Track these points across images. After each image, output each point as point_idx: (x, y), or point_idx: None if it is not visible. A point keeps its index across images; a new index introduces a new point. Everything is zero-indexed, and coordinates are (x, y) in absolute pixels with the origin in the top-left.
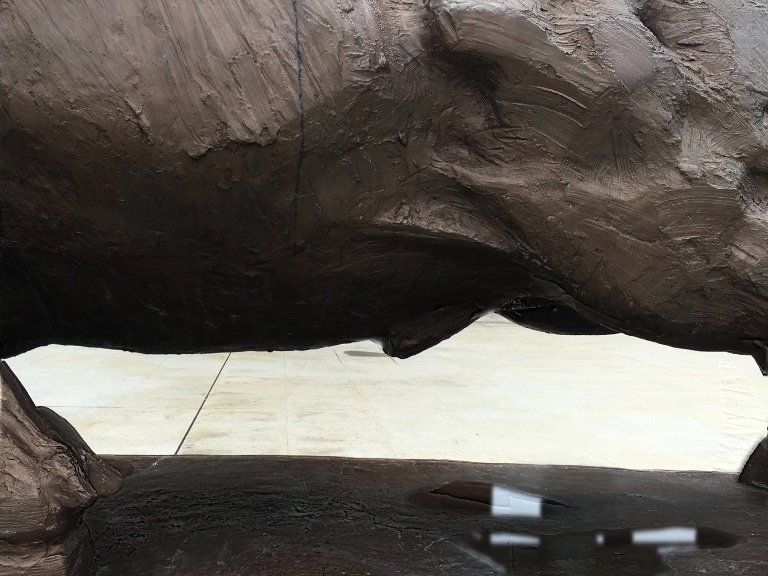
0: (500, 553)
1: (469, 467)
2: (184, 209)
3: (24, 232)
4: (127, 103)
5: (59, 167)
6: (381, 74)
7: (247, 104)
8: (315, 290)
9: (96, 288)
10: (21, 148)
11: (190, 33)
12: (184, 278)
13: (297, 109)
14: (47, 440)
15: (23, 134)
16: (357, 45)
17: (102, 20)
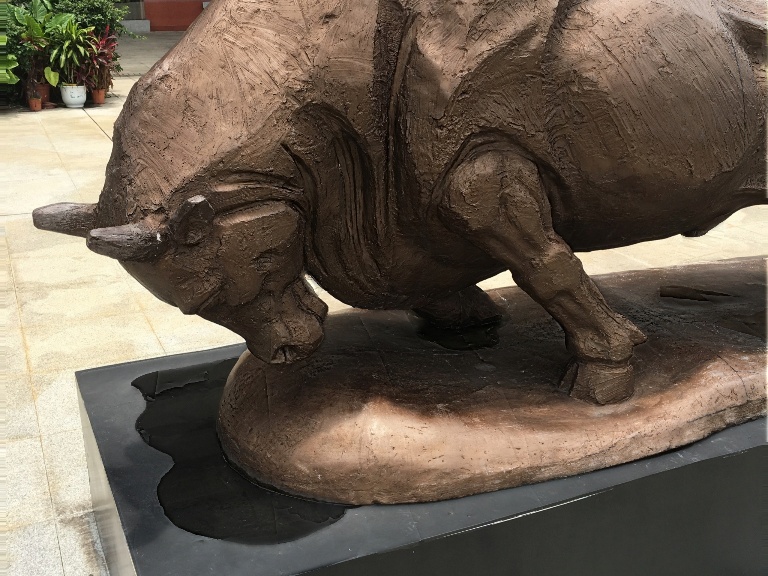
0: (746, 329)
1: (653, 276)
2: None
3: (596, 214)
4: (687, 161)
5: (642, 189)
6: (763, 124)
7: None
8: None
9: (607, 233)
10: None
11: (710, 122)
12: (654, 225)
13: (743, 151)
14: (617, 315)
15: None
16: (761, 113)
17: (678, 121)
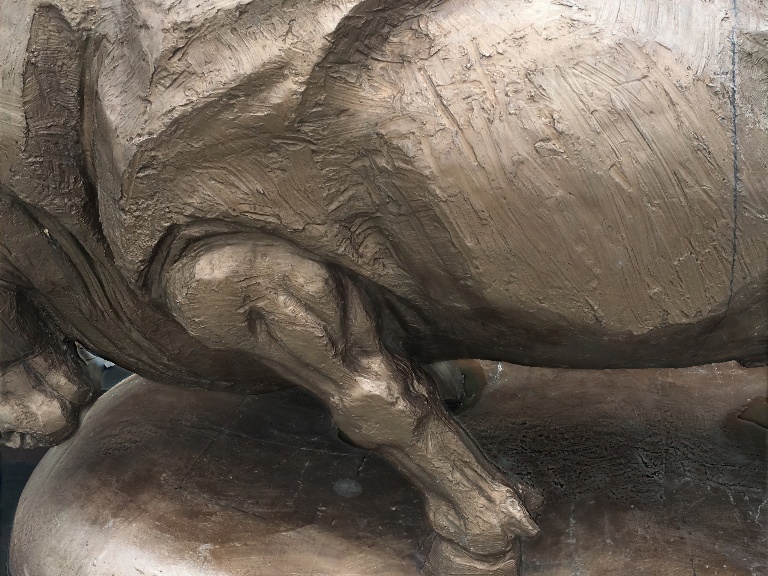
0: None
1: (764, 372)
2: (616, 351)
3: None
4: (587, 300)
5: (519, 326)
6: None
7: (686, 295)
8: (698, 363)
9: None
10: (490, 314)
11: (643, 241)
12: None
13: (727, 293)
14: (498, 486)
15: (495, 311)
16: None
17: (568, 234)
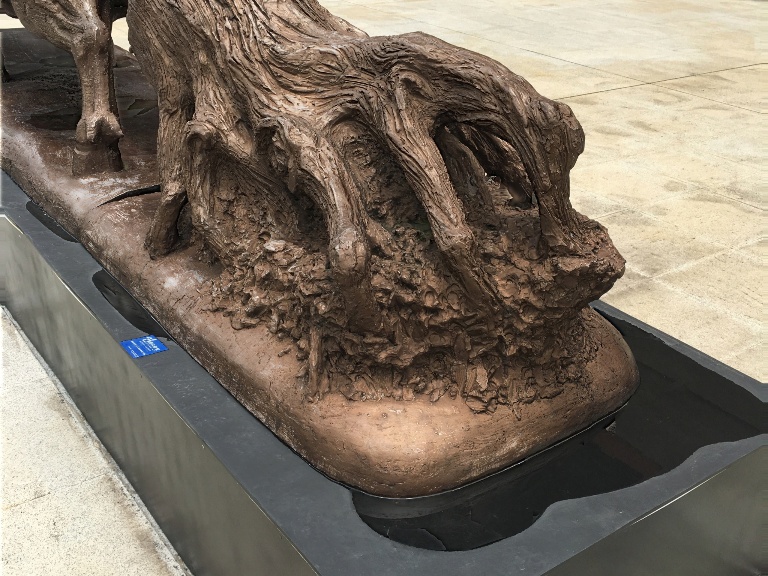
0: (62, 113)
1: None
2: None
3: None
4: None
5: None
6: None
7: None
8: None
9: None
10: None
11: None
12: None
13: None
14: None
15: None
16: None
17: None
